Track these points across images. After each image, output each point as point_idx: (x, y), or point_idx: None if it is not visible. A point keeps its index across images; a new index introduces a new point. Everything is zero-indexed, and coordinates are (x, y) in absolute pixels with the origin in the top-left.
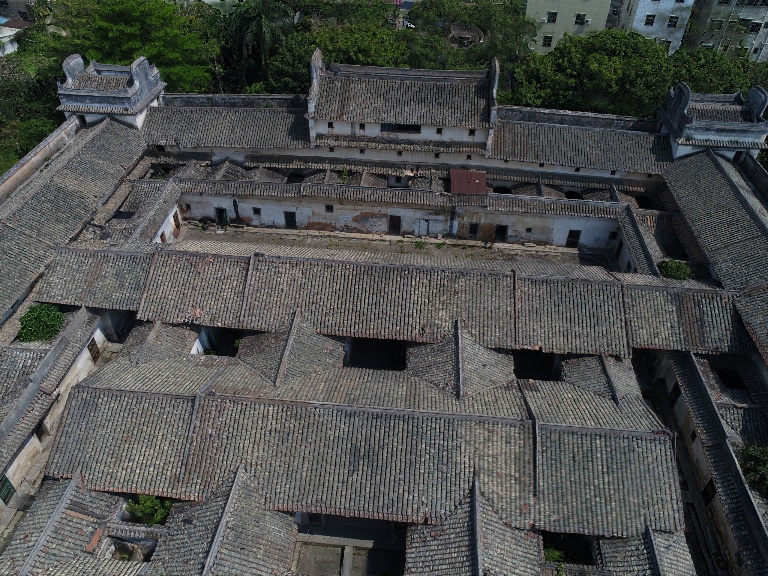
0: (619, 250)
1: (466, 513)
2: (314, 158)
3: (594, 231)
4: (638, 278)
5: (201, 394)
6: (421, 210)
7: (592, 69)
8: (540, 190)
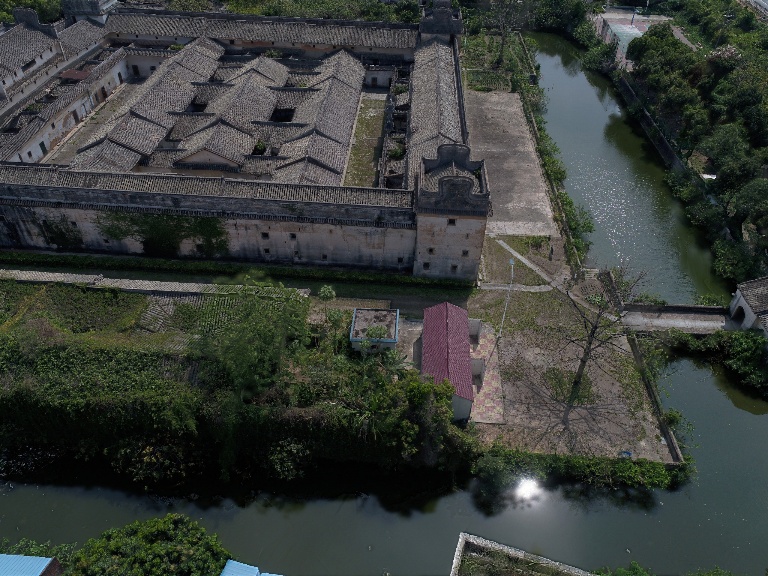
0: (136, 70)
1: (278, 91)
2: (8, 112)
3: (122, 69)
4: None
5: None
6: (79, 99)
7: (29, 3)
8: (94, 62)
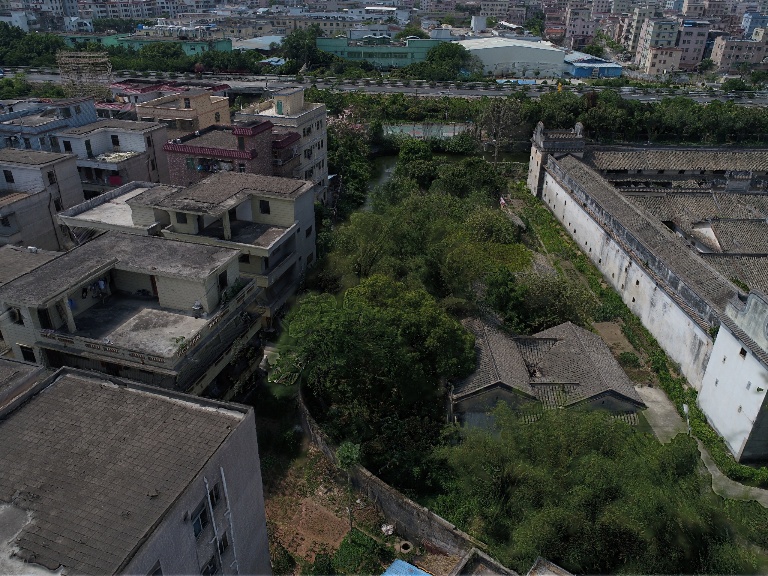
0: None
1: None
2: None
3: None
4: (759, 279)
5: None
6: None
7: None
8: None
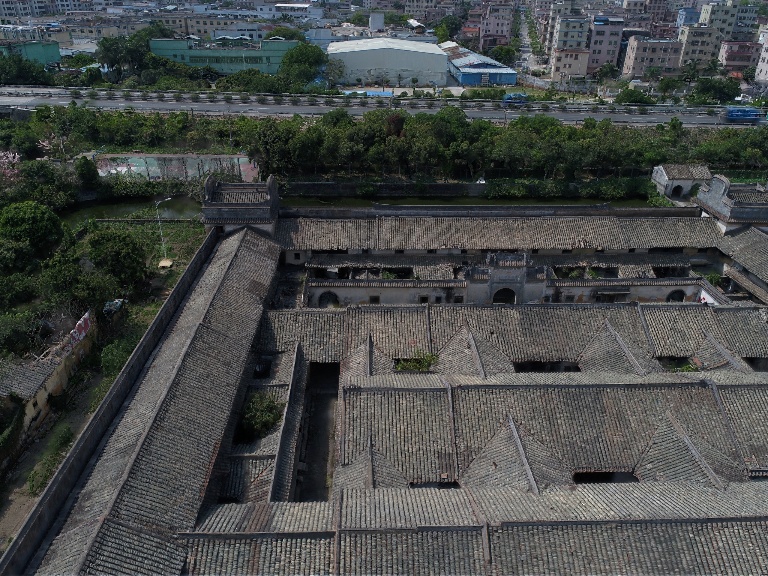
0: None
1: None
2: None
3: None
4: None
5: (710, 383)
6: None
7: None
8: None
